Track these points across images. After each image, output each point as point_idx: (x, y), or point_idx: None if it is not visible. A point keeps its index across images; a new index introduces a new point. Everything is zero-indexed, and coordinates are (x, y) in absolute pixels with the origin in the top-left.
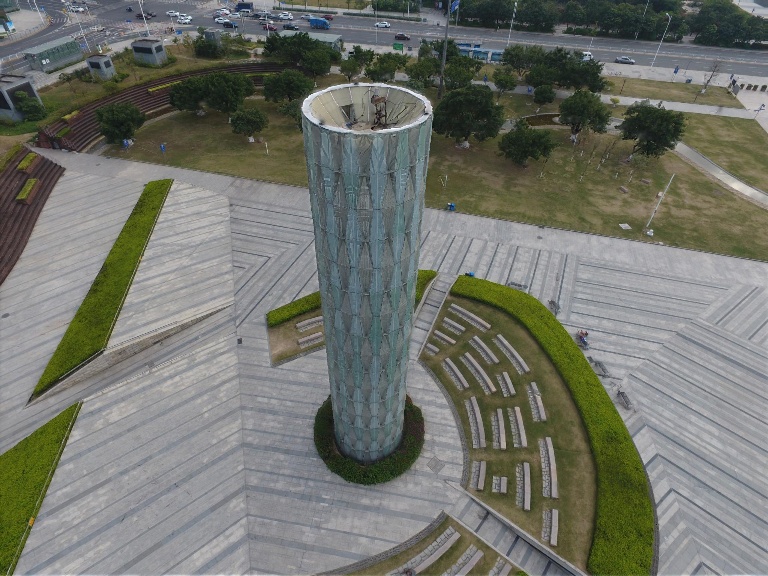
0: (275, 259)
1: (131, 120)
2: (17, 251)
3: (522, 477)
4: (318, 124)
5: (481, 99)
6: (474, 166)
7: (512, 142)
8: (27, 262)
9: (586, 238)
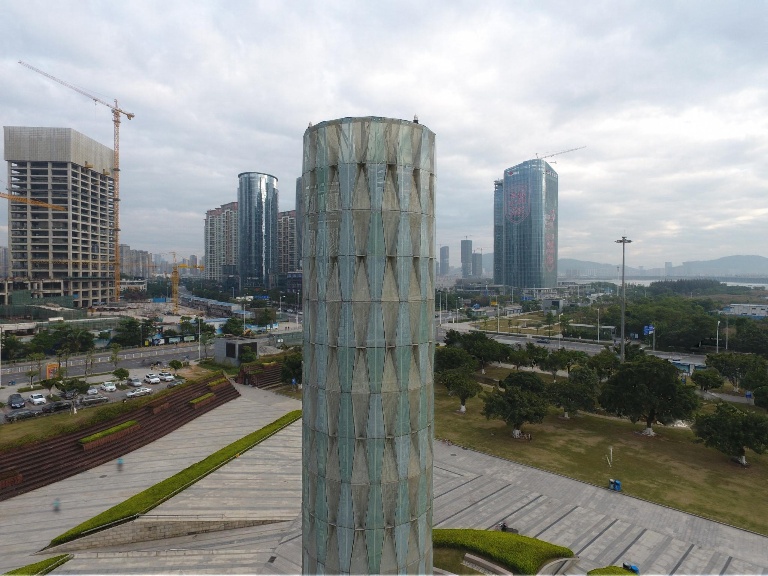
0: None
1: None
2: (158, 435)
3: None
4: None
5: (658, 371)
6: (659, 453)
7: (712, 425)
8: (157, 444)
9: None
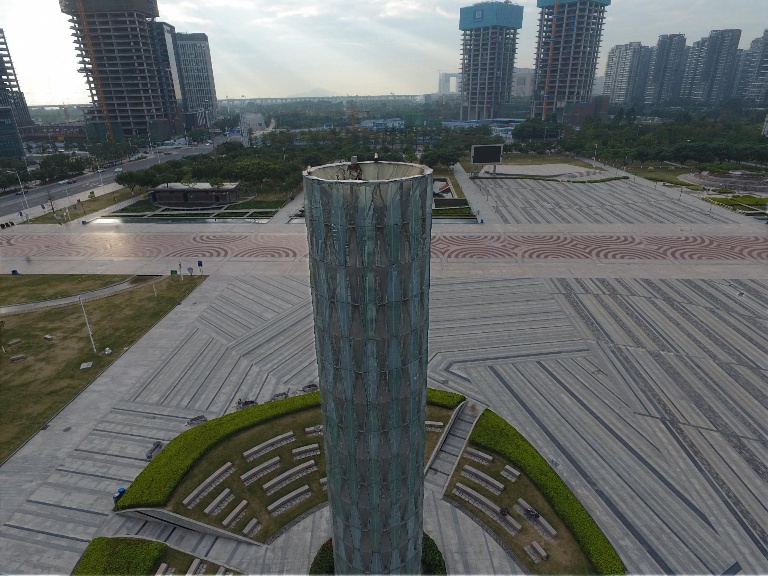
0: None
1: None
2: None
3: None
4: (424, 174)
5: None
6: None
7: None
8: None
9: (90, 393)
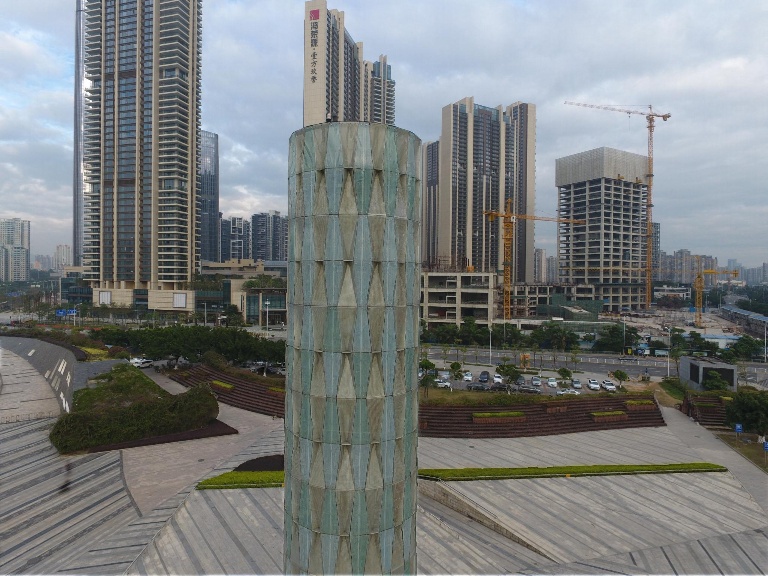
0: None
1: (767, 412)
2: (539, 433)
3: None
4: None
5: None
6: None
7: None
8: (532, 440)
9: None
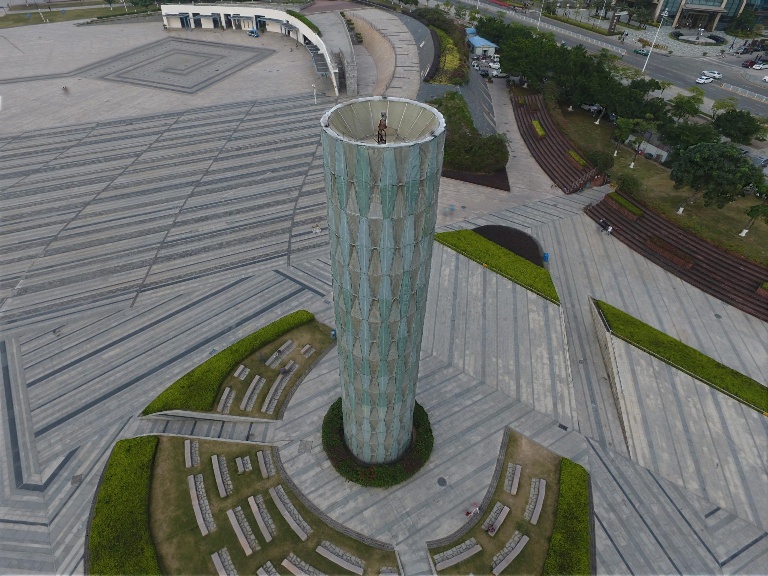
0: (712, 568)
1: None
2: None
3: (225, 483)
4: None
5: None
6: None
7: None
8: None
9: None
